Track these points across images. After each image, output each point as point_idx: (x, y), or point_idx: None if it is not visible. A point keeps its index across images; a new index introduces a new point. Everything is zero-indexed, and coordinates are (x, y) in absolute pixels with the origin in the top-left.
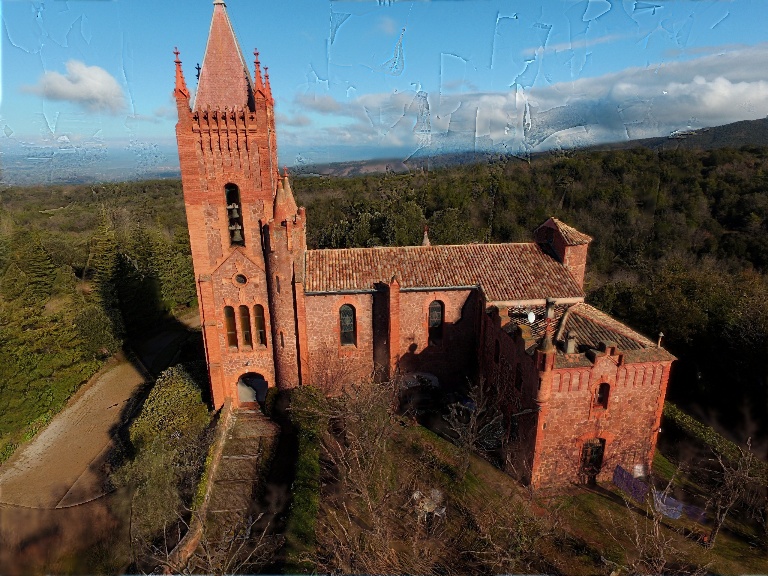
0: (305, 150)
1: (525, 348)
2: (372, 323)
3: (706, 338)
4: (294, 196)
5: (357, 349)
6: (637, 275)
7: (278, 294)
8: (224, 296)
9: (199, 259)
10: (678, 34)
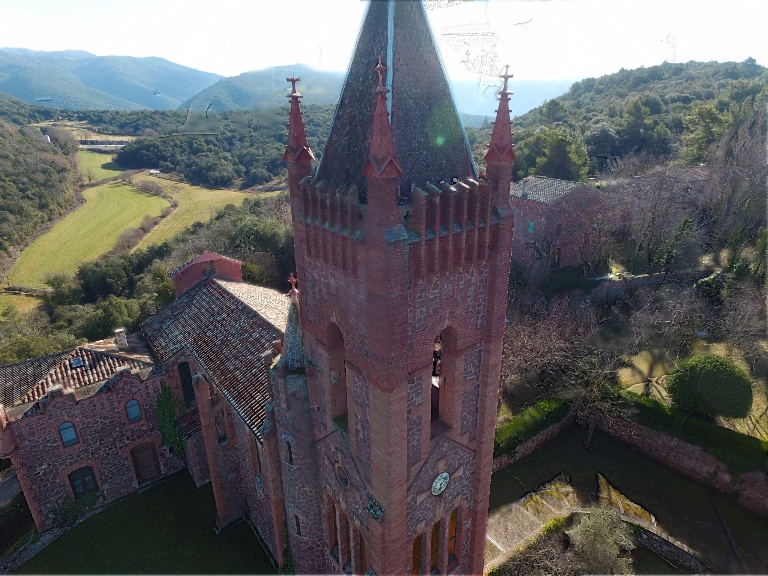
0: None
1: None
2: None
3: None
4: None
5: None
6: None
7: None
8: None
9: None
10: None
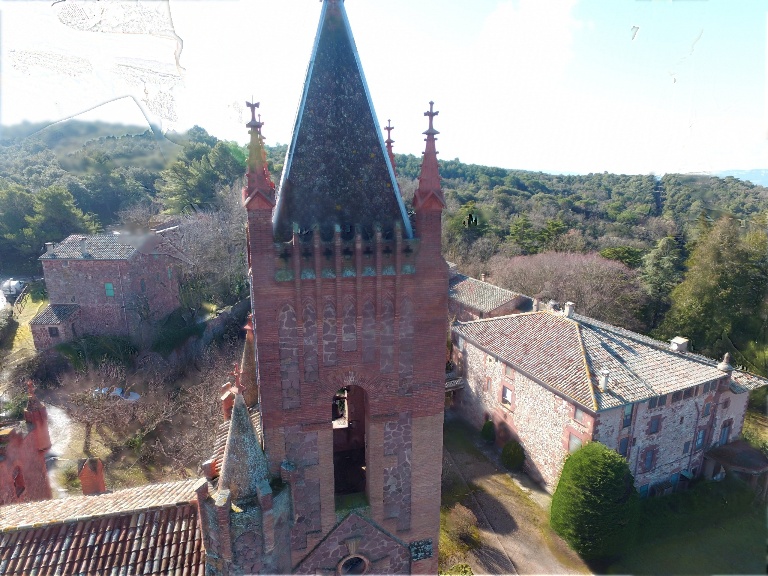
0: None
1: (22, 437)
2: None
3: None
4: None
5: None
6: None
7: None
8: None
9: None
10: None
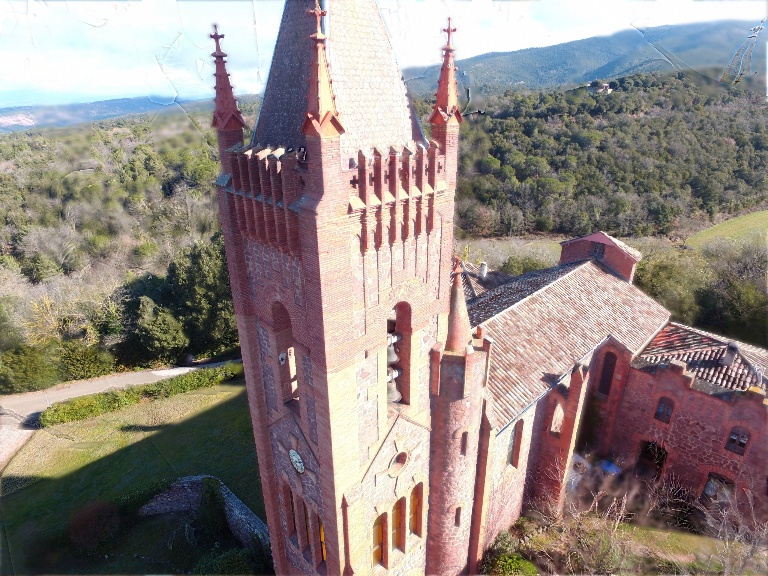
0: (48, 128)
1: None
2: (532, 429)
3: (698, 317)
4: (40, 201)
5: (517, 469)
6: (500, 244)
7: (462, 457)
8: (375, 503)
9: (344, 467)
10: (499, 8)
